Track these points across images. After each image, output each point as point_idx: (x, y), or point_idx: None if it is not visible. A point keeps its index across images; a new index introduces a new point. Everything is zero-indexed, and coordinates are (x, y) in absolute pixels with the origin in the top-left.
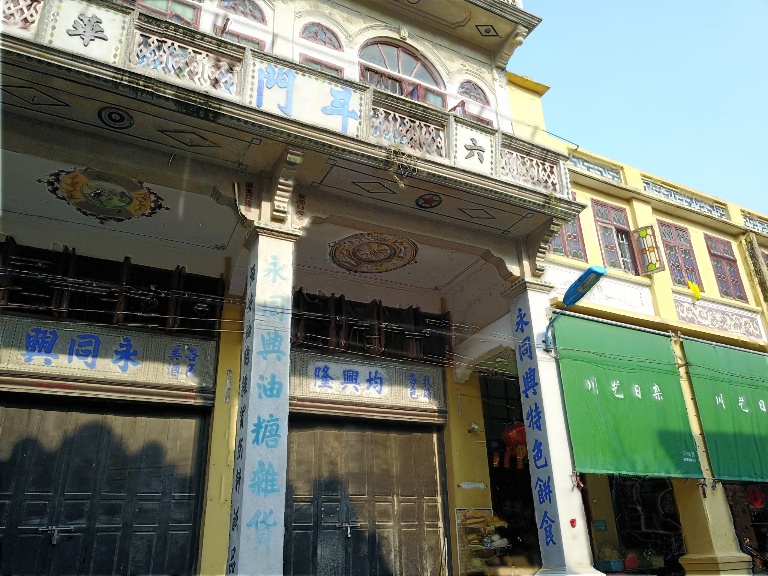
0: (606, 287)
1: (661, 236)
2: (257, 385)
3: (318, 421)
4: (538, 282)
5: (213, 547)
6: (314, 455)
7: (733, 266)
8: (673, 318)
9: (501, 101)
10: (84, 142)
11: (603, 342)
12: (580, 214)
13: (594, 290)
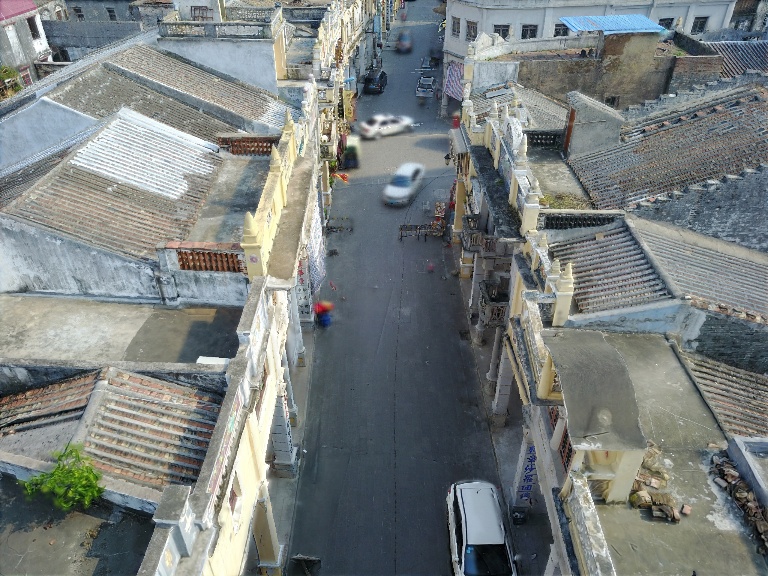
0: None
1: None
2: (389, 4)
3: None
4: None
5: None
6: None
7: None
8: None
9: None
10: None
11: None
12: None
13: None
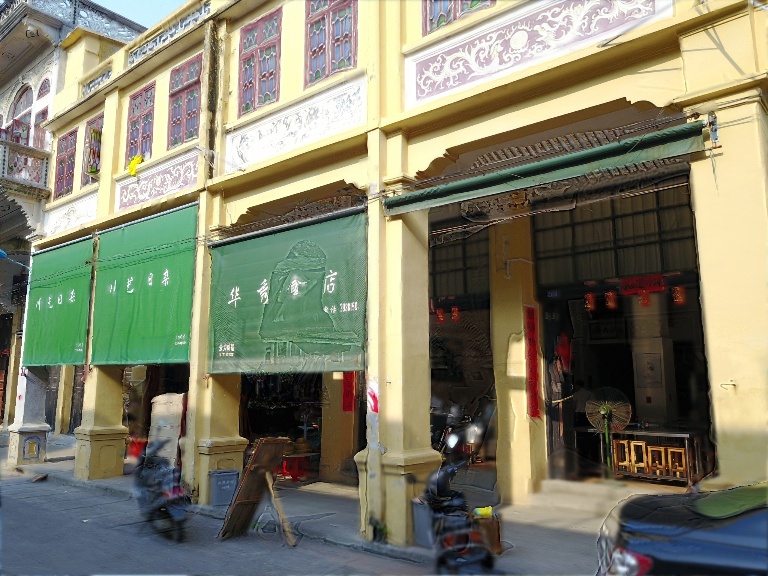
0: (78, 209)
1: (128, 116)
2: None
3: None
4: (31, 236)
5: (59, 398)
6: None
7: (197, 90)
8: (103, 214)
9: (53, 80)
10: None
11: (51, 266)
12: (77, 147)
13: (71, 217)
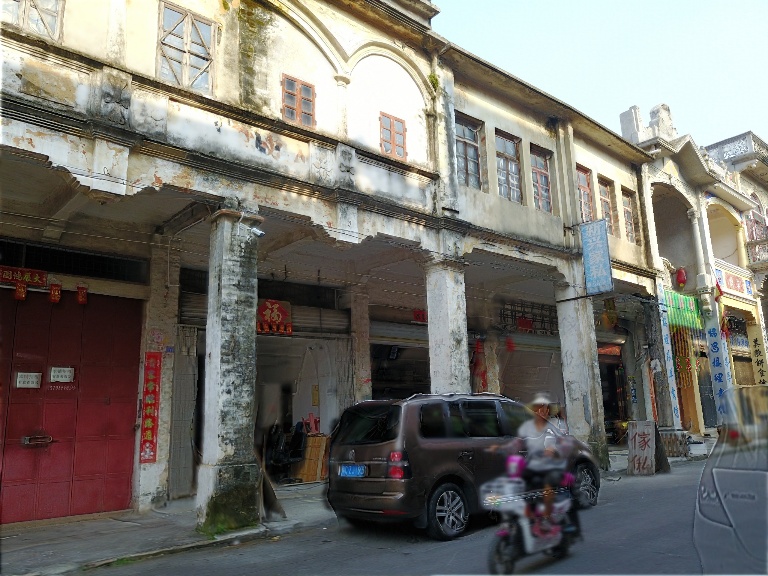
0: None
1: None
2: None
3: (735, 358)
4: None
5: None
6: (736, 371)
7: None
8: None
9: None
10: (767, 282)
11: None
12: None
13: None
